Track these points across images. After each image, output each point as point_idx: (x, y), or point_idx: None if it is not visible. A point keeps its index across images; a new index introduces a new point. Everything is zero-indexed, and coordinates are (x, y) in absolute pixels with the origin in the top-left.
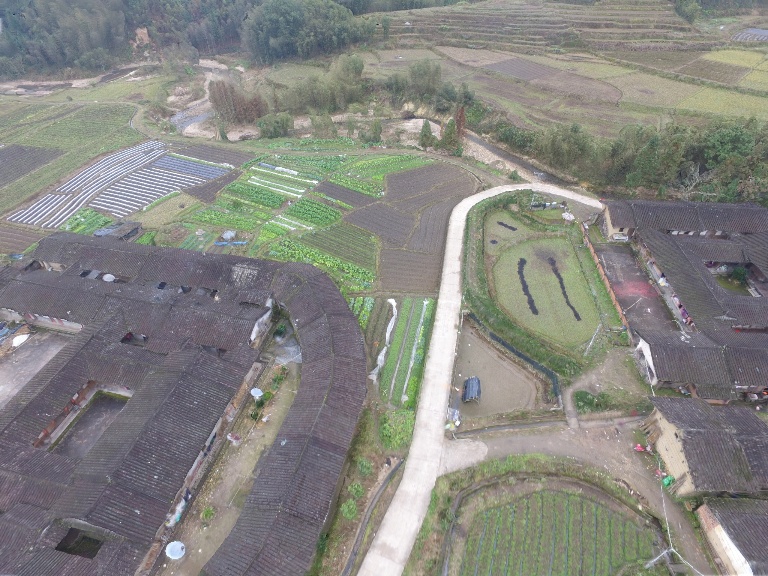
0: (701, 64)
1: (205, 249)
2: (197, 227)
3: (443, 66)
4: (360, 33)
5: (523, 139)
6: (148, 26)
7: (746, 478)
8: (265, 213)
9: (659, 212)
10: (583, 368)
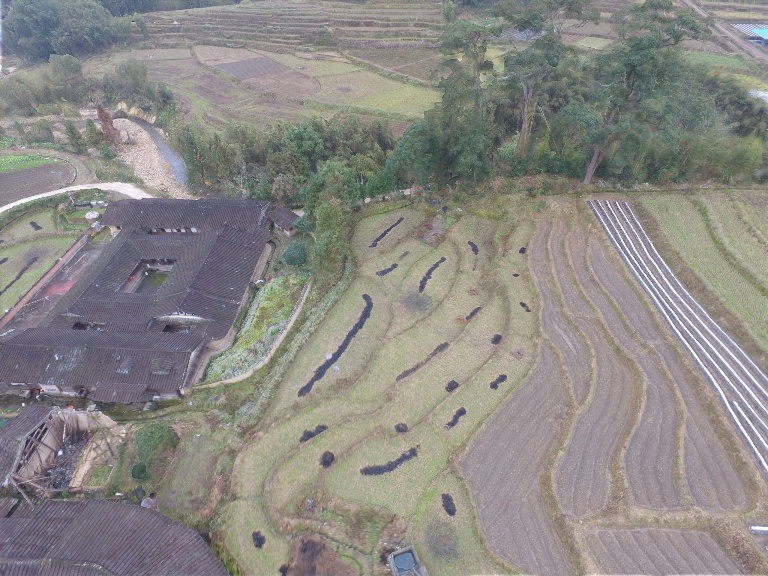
0: (430, 62)
1: None
2: None
3: (182, 65)
4: (113, 32)
5: None
6: None
7: None
8: None
9: (151, 210)
10: None
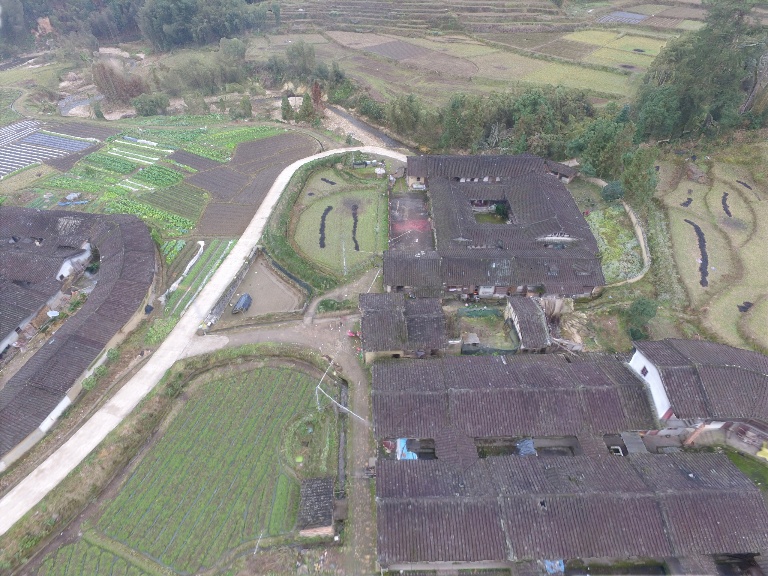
0: (559, 43)
1: (48, 209)
2: (46, 191)
3: (327, 49)
4: (251, 19)
5: (379, 111)
6: (49, 15)
7: (402, 341)
8: (114, 178)
9: (448, 163)
10: (339, 283)
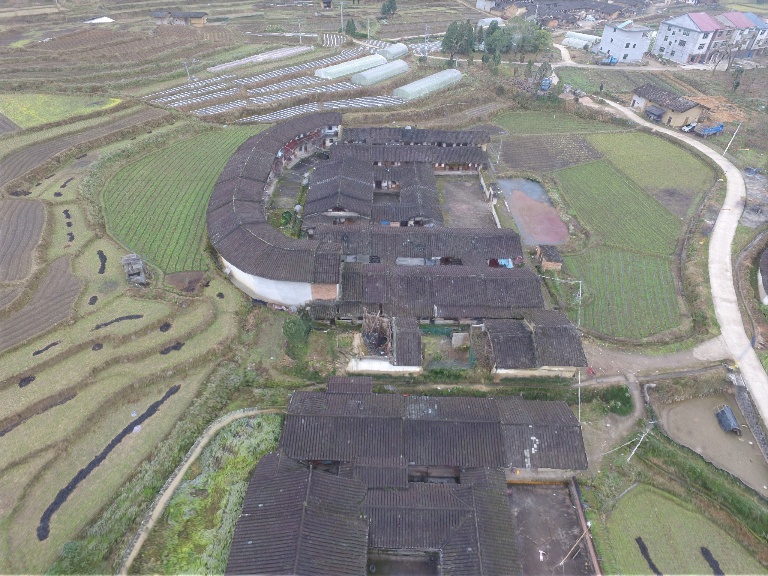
0: None
1: None
2: None
3: None
4: None
5: None
6: None
7: None
8: None
9: None
10: None
